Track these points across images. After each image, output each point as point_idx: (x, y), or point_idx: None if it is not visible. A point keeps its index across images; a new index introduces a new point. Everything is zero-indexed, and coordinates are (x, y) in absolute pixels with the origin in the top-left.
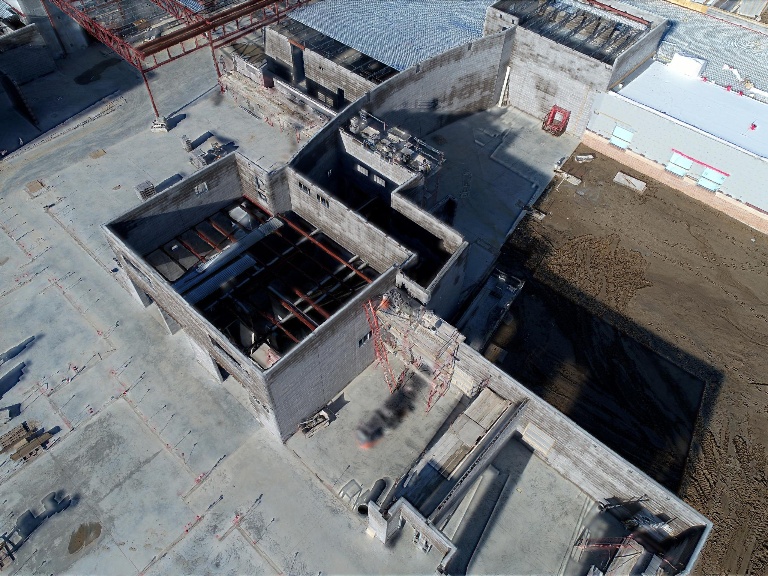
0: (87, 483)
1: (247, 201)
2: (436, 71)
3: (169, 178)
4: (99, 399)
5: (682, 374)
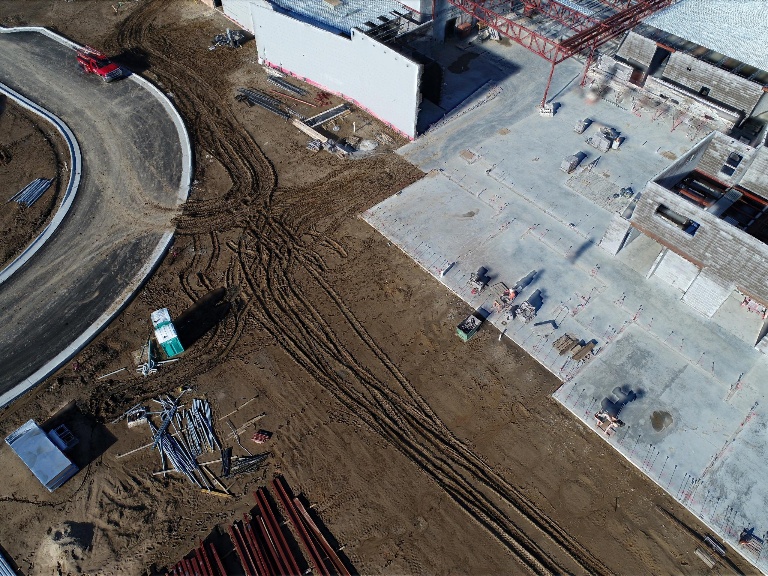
0: (641, 383)
1: (694, 174)
2: None
3: (575, 154)
4: (616, 322)
5: None
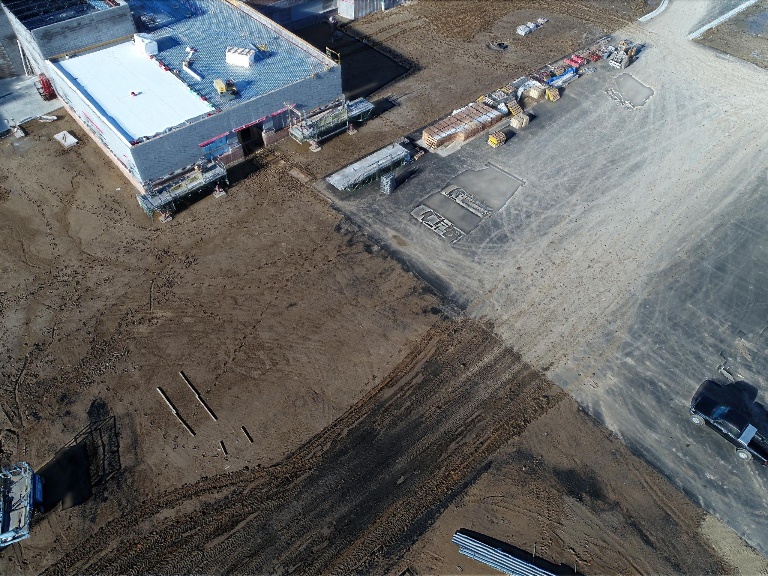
0: None
1: None
2: None
3: None
4: None
5: None
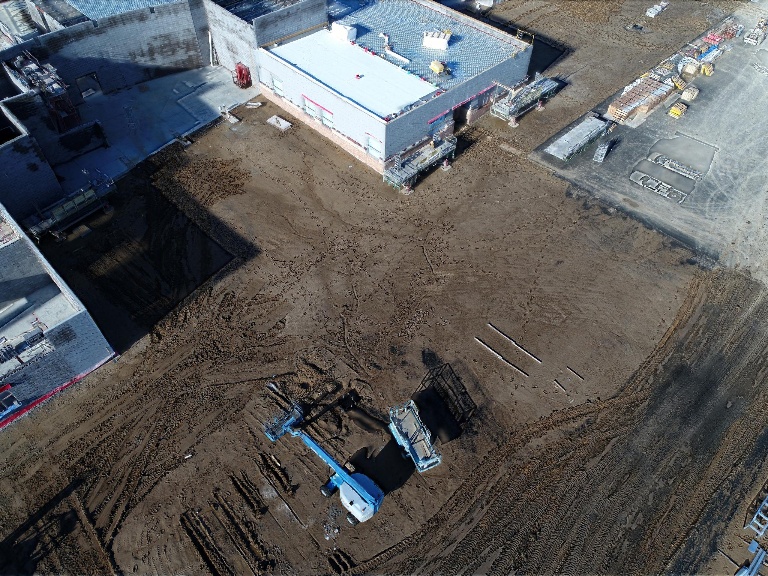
0: None
1: None
2: (120, 28)
3: None
4: None
5: (220, 251)
